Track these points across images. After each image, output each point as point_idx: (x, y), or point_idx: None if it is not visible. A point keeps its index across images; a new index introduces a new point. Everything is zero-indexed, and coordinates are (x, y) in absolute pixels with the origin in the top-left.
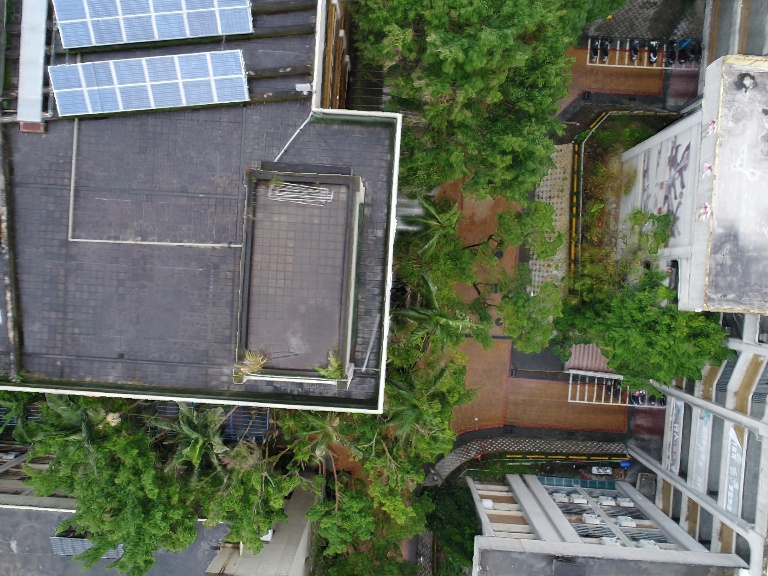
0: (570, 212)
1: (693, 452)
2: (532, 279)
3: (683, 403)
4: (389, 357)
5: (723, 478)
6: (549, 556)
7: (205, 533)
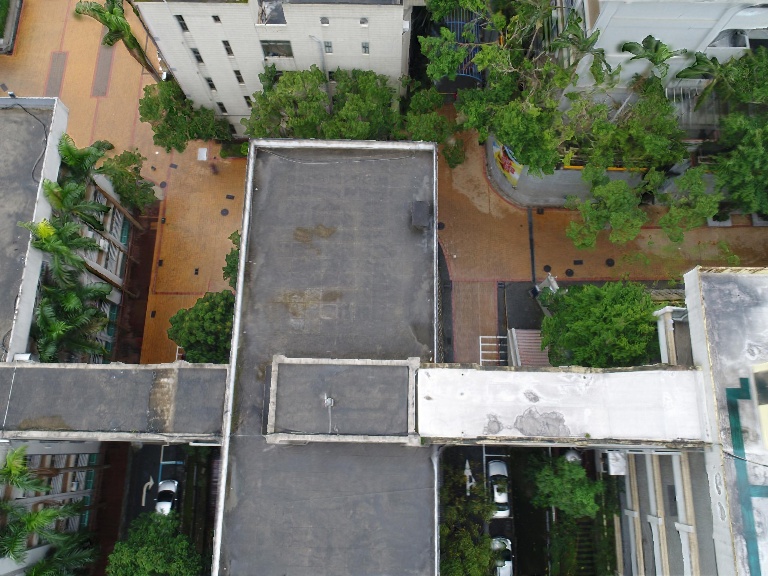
0: None
1: None
2: None
3: None
4: (594, 60)
5: None
6: None
7: None
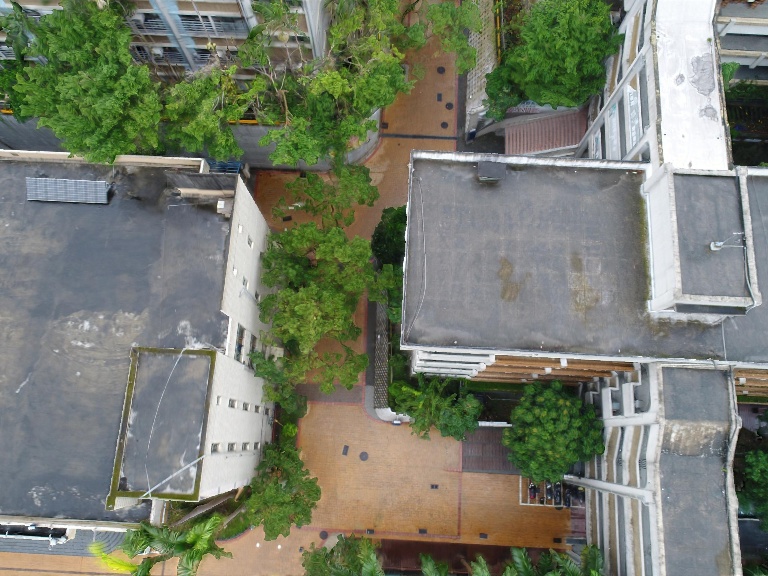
0: (495, 15)
1: (608, 147)
2: (470, 86)
3: (599, 130)
4: None
5: (628, 129)
6: (475, 169)
7: (168, 182)
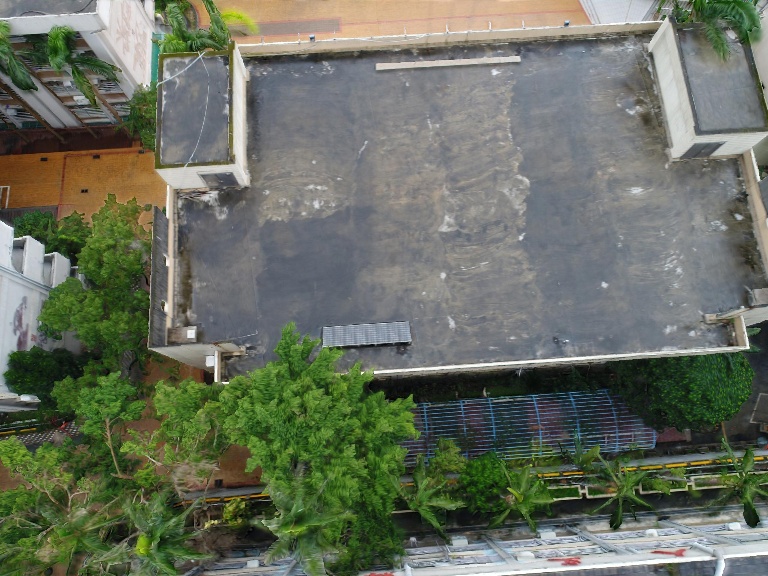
0: None
1: None
2: None
3: None
4: None
5: None
6: None
7: (263, 362)
